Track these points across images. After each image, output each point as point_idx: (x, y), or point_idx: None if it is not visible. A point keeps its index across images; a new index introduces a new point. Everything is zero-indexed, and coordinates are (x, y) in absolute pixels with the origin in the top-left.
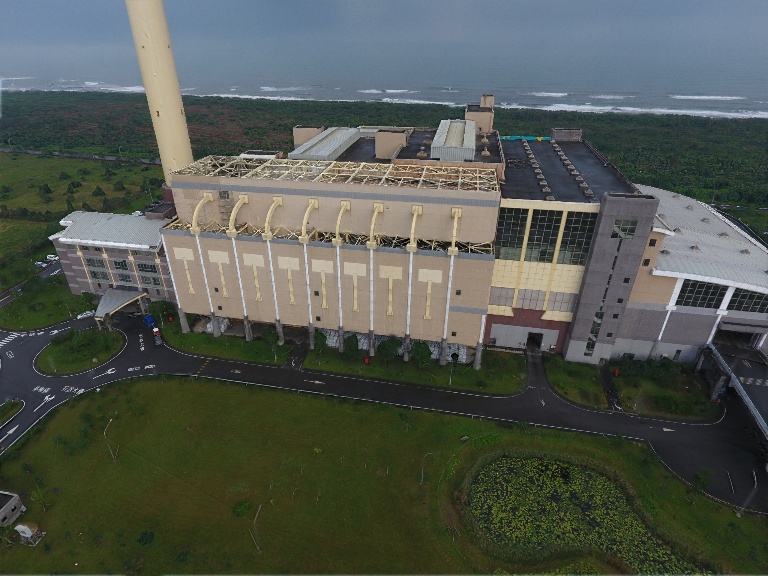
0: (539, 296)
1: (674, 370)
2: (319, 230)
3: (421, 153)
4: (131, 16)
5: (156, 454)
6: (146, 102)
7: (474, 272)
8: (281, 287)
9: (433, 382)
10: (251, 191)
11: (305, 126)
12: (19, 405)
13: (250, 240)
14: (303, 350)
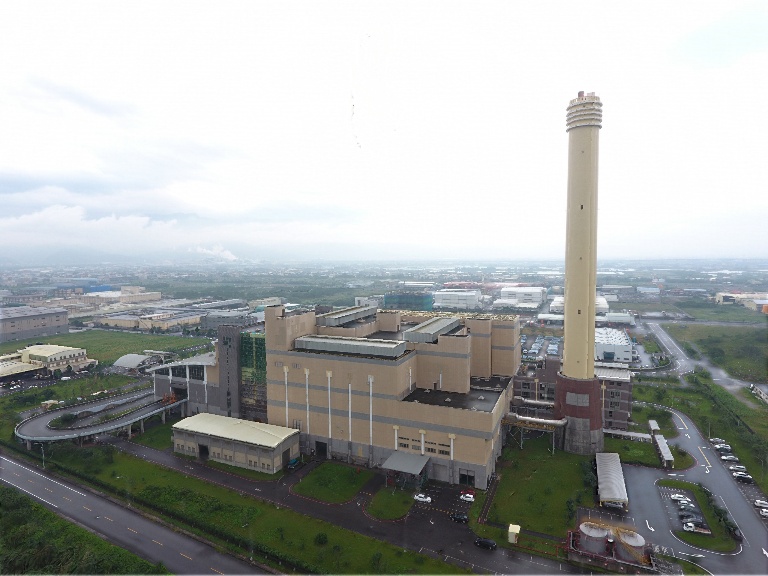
0: None
1: None
2: None
3: None
4: None
5: None
6: None
7: None
8: None
9: None
10: None
11: (459, 337)
12: None
13: None
14: None
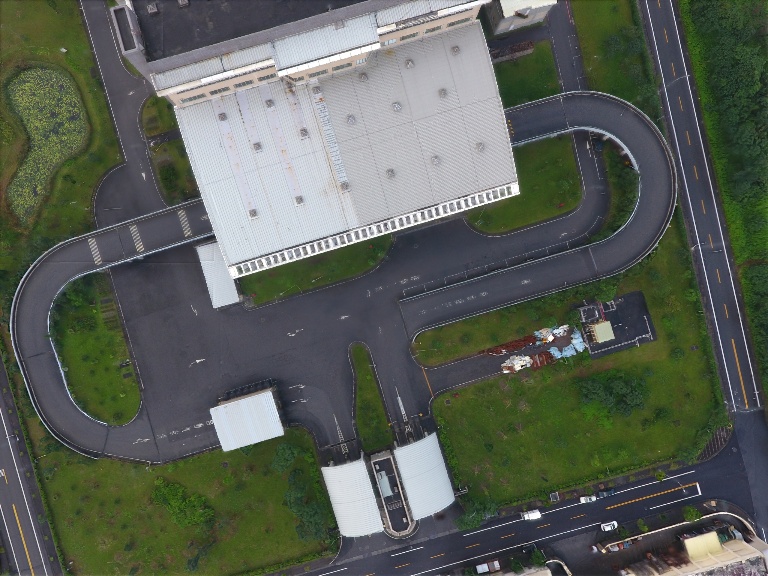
0: None
1: (192, 173)
2: None
3: None
4: None
5: None
6: None
7: None
8: None
9: None
10: None
11: None
12: None
13: None
14: None
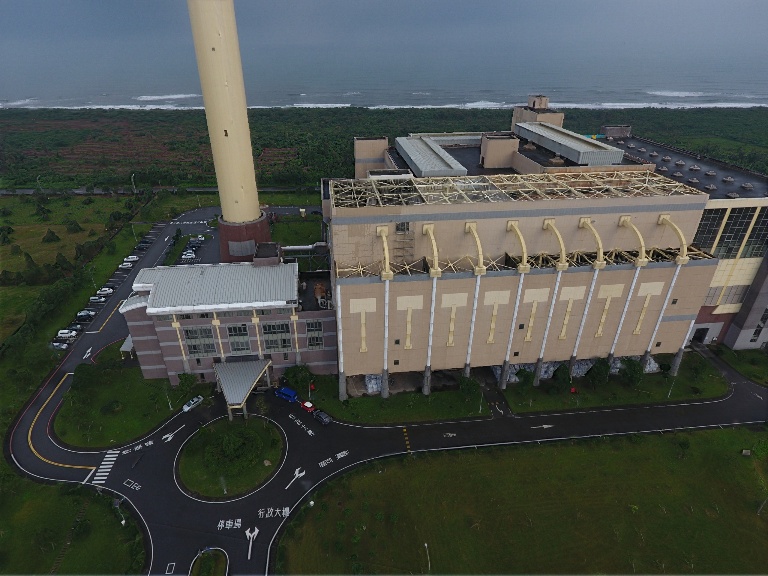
0: (716, 292)
1: None
2: (512, 255)
3: (557, 159)
4: (198, 9)
5: (467, 569)
6: (4, 119)
7: (696, 279)
8: (481, 326)
9: (652, 399)
10: (438, 219)
11: (364, 138)
12: (221, 556)
13: (456, 277)
14: (495, 392)
